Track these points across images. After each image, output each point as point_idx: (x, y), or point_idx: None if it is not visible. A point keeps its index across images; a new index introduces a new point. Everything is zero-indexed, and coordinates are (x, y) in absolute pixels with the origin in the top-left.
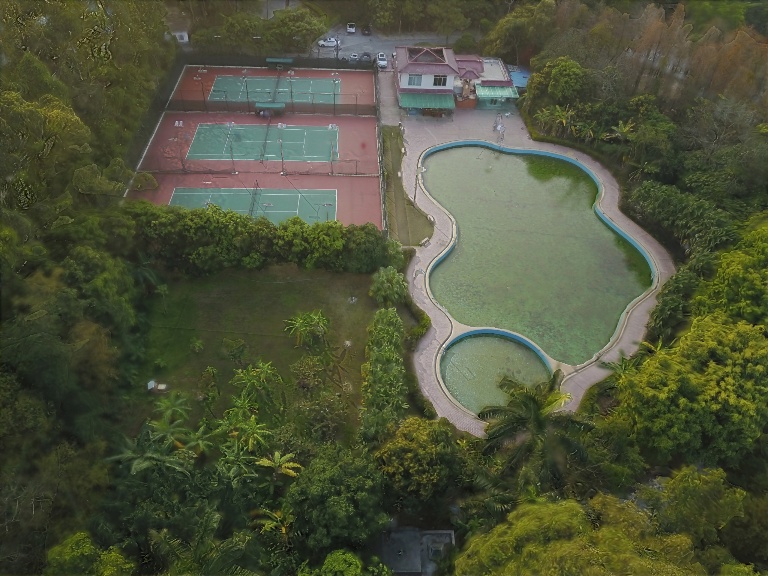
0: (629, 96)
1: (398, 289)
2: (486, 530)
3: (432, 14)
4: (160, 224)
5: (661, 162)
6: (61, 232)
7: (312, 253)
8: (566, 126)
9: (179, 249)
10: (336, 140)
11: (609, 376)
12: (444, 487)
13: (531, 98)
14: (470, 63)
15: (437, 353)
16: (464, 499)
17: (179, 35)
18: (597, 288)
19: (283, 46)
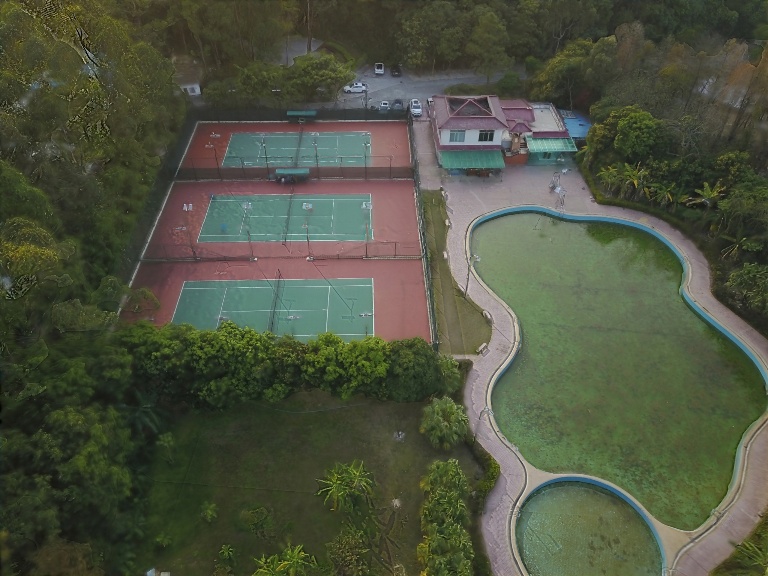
0: (714, 152)
1: (457, 428)
2: None
3: (471, 54)
4: (162, 356)
5: (765, 239)
6: None
7: (349, 381)
8: (638, 188)
9: (186, 383)
10: (369, 212)
11: (738, 552)
12: None
13: (592, 152)
14: (518, 111)
15: (510, 516)
16: None
17: (190, 88)
18: (700, 408)
19: (305, 96)
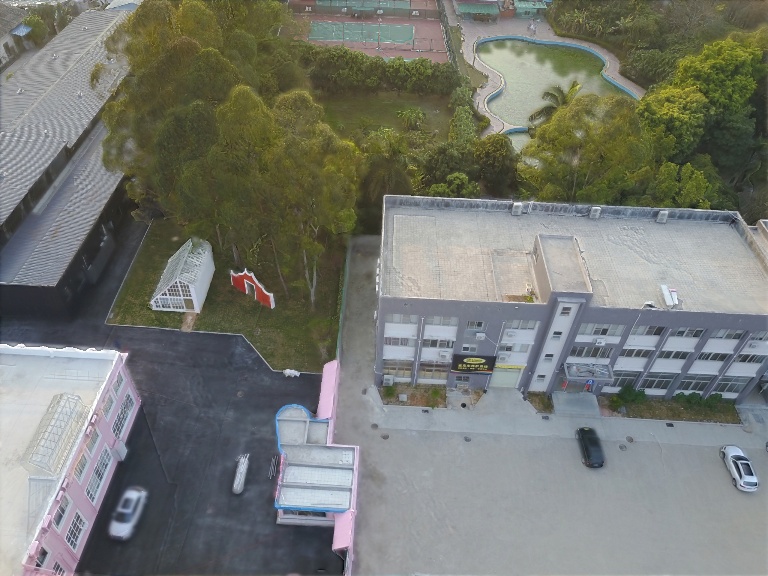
0: None
1: (469, 100)
2: (531, 200)
3: None
4: (316, 52)
5: (650, 39)
6: (266, 43)
7: (411, 78)
8: (582, 23)
9: (326, 71)
10: None
11: None
12: (507, 171)
13: (556, 7)
14: None
15: None
16: (517, 187)
17: None
18: None
19: None
